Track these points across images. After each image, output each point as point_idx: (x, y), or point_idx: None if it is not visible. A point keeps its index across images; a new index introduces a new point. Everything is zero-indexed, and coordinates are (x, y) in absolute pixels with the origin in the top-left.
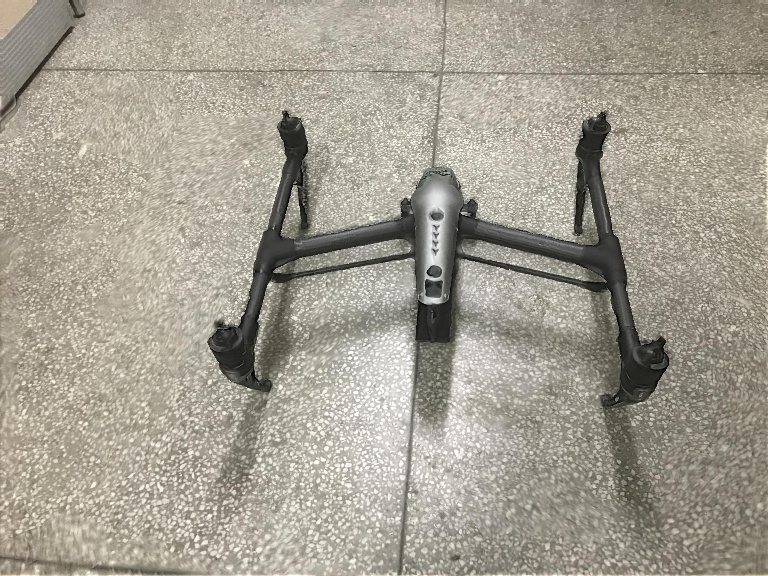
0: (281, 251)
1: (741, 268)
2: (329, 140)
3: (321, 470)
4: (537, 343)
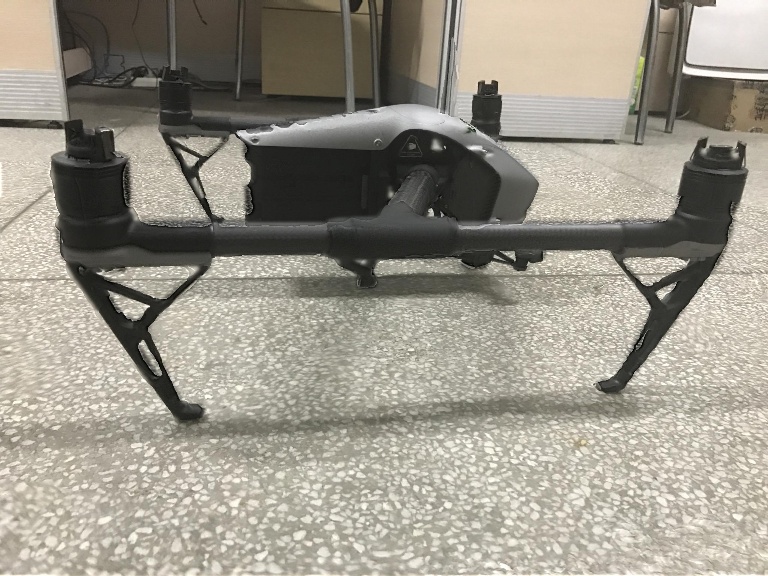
0: None
1: None
2: (598, 222)
3: None
4: (311, 352)
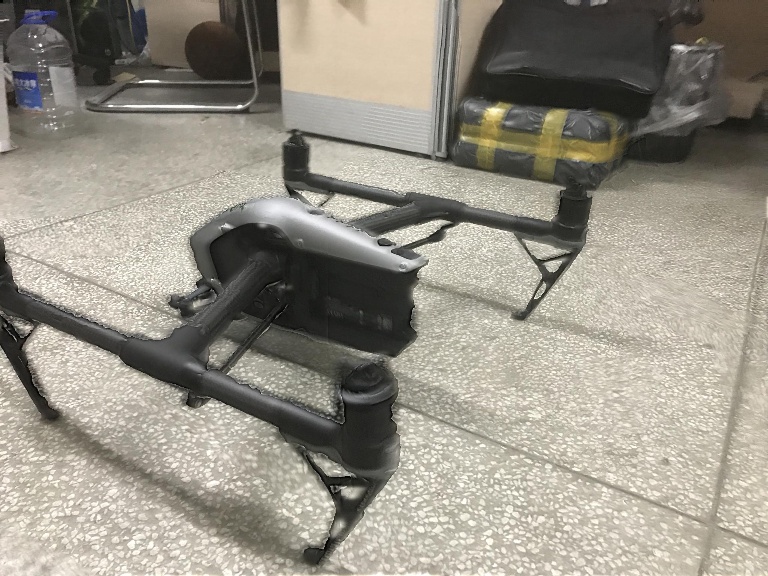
0: (189, 344)
1: (433, 228)
2: None
3: (505, 540)
4: (430, 324)
